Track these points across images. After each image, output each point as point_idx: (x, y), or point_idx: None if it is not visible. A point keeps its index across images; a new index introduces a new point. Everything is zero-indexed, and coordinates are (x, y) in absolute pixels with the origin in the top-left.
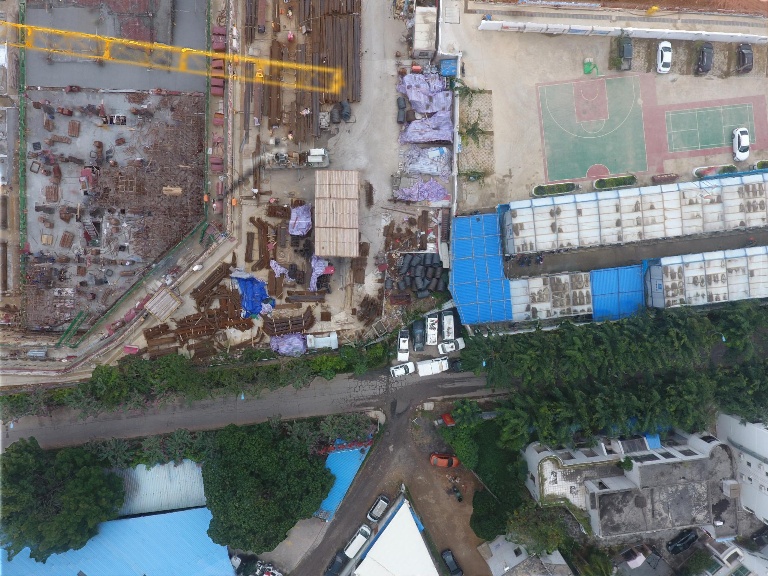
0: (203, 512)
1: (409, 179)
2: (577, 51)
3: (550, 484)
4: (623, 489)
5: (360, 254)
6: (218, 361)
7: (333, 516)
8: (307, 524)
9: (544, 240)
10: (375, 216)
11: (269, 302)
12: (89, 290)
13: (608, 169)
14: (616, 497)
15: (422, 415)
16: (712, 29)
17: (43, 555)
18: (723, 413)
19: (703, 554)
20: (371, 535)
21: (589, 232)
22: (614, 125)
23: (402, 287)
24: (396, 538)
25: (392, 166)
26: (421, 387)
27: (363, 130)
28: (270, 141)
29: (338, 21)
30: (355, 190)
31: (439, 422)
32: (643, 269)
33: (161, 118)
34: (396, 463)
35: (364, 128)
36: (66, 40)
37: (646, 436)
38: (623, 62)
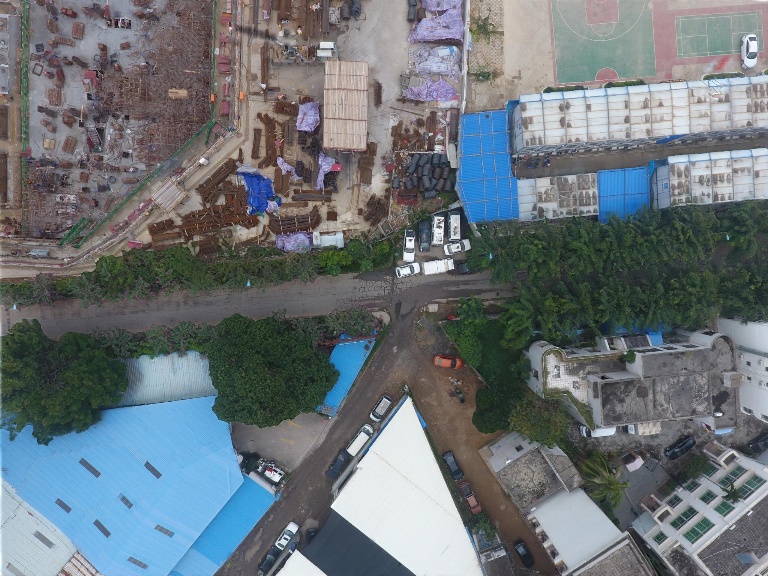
0: (207, 401)
1: (418, 78)
2: None
3: (553, 378)
4: (626, 378)
5: (367, 154)
6: (223, 258)
7: (336, 416)
8: (310, 423)
9: (553, 135)
10: (383, 116)
11: (275, 200)
12: (92, 196)
13: (617, 73)
14: (618, 387)
15: (426, 316)
16: None
17: (46, 435)
18: (724, 317)
19: (700, 458)
20: (373, 434)
21: (598, 128)
22: (624, 29)
23: (409, 186)
24: (399, 433)
25: (401, 65)
26: (426, 289)
27: (373, 28)
28: (279, 33)
29: None
30: (365, 81)
31: (443, 321)
32: (650, 171)
33: (167, 23)
34: (399, 364)
35: (374, 26)
36: None
37: (649, 333)
38: None
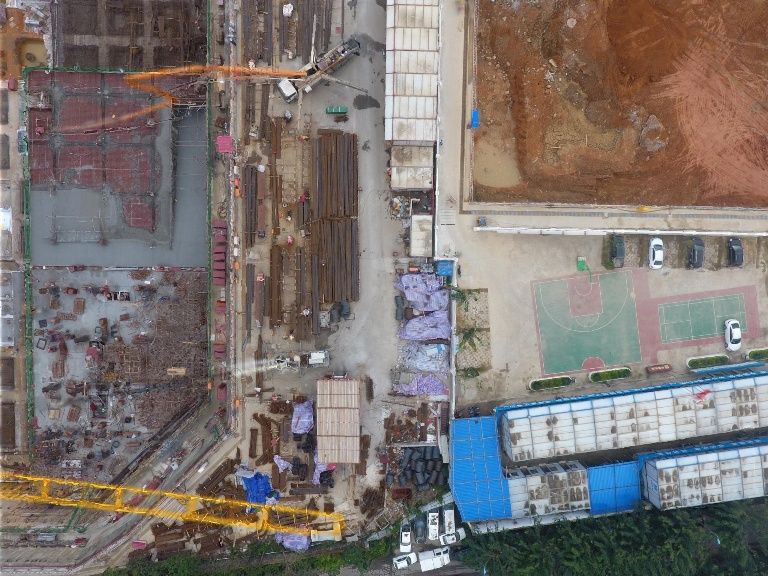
0: None
1: (408, 374)
2: (570, 248)
3: None
4: None
5: (361, 446)
6: (224, 555)
7: None
8: None
9: (541, 448)
10: (375, 409)
11: (273, 496)
12: (96, 463)
13: (603, 361)
14: None
15: None
16: (702, 222)
17: None
18: None
19: None
20: None
21: (585, 439)
22: (608, 318)
23: (403, 482)
24: None
25: (391, 360)
26: (423, 575)
27: (362, 326)
28: (272, 346)
29: (336, 225)
30: (356, 399)
31: None
32: (639, 465)
33: (164, 293)
34: None
35: (363, 324)
36: (70, 221)
37: None
38: (616, 260)
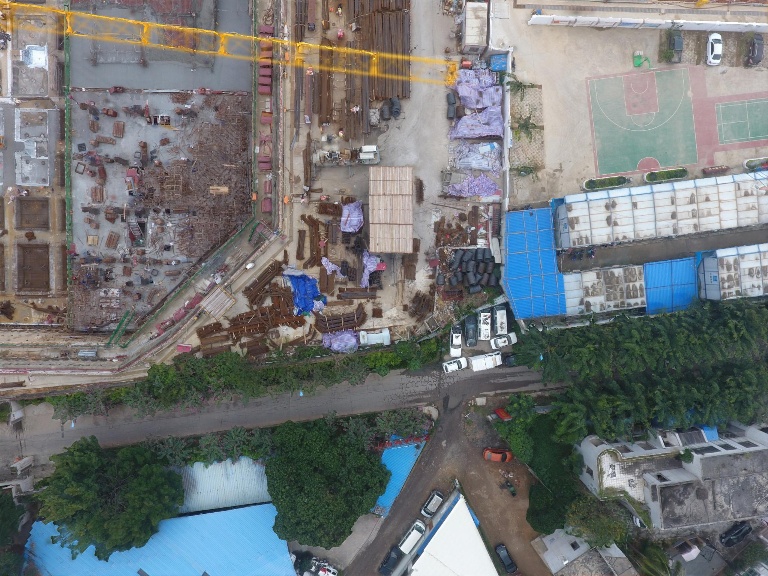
0: (262, 509)
1: (459, 175)
2: (626, 44)
3: (608, 477)
4: (685, 481)
5: None
6: (271, 359)
7: None
8: (361, 520)
9: (599, 233)
10: (425, 212)
11: (321, 299)
12: (135, 290)
13: (658, 162)
14: (677, 489)
15: (475, 410)
16: (761, 20)
17: (107, 553)
18: None
19: (758, 546)
20: (426, 530)
21: (644, 225)
22: (664, 118)
23: (454, 282)
24: (453, 533)
25: (442, 162)
26: (473, 382)
27: (413, 126)
28: (322, 138)
29: (388, 18)
30: (409, 186)
31: (493, 417)
32: (696, 261)
33: (205, 118)
34: (449, 458)
35: (414, 124)
36: (110, 41)
37: (703, 428)
38: None
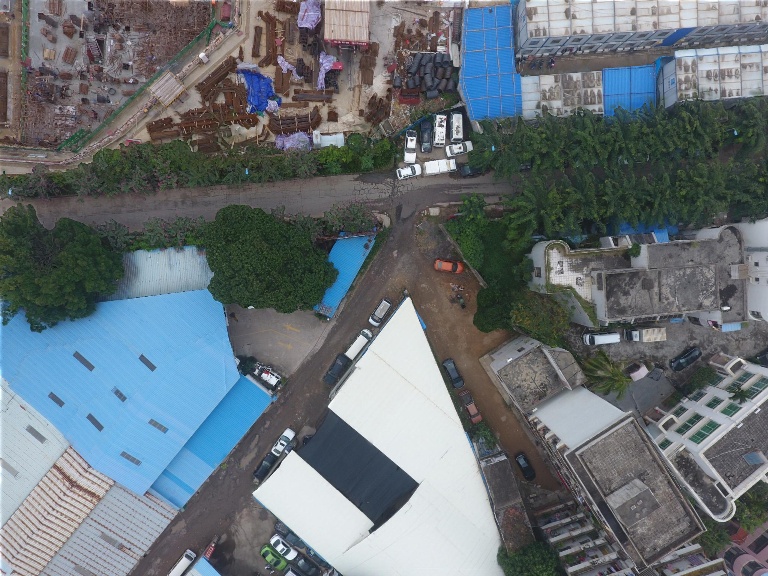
0: (203, 293)
1: None
2: None
3: (556, 274)
4: (630, 269)
5: (369, 54)
6: None
7: (334, 320)
8: (308, 328)
9: (557, 26)
10: (385, 16)
11: (275, 99)
12: (91, 106)
13: None
14: (623, 279)
15: (427, 219)
16: None
17: (39, 319)
18: (731, 222)
19: (706, 368)
20: (372, 338)
21: (603, 20)
22: None
23: (411, 85)
24: (398, 333)
25: None
26: (427, 192)
27: None
28: None
29: None
30: None
31: None
32: (656, 69)
33: None
34: (400, 269)
35: None
36: None
37: (654, 231)
38: None
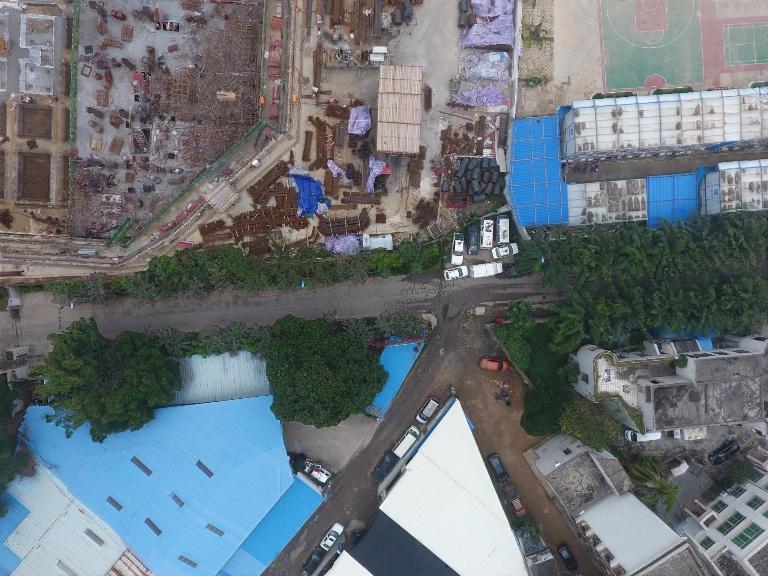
0: (259, 400)
1: (468, 83)
2: None
3: (603, 382)
4: (678, 383)
5: (417, 157)
6: (273, 259)
7: (382, 417)
8: (356, 424)
9: (605, 140)
10: (433, 120)
11: (325, 202)
12: (137, 196)
13: (665, 80)
14: (671, 391)
15: (474, 319)
16: None
17: (102, 433)
18: None
19: (745, 463)
20: (420, 436)
21: (649, 134)
22: (673, 36)
23: (459, 189)
24: (447, 435)
25: (451, 70)
26: (473, 292)
27: (424, 33)
28: (333, 37)
29: None
30: (419, 86)
31: (492, 324)
32: (698, 177)
33: (214, 26)
34: (446, 367)
35: (425, 31)
36: None
37: (698, 338)
38: None
